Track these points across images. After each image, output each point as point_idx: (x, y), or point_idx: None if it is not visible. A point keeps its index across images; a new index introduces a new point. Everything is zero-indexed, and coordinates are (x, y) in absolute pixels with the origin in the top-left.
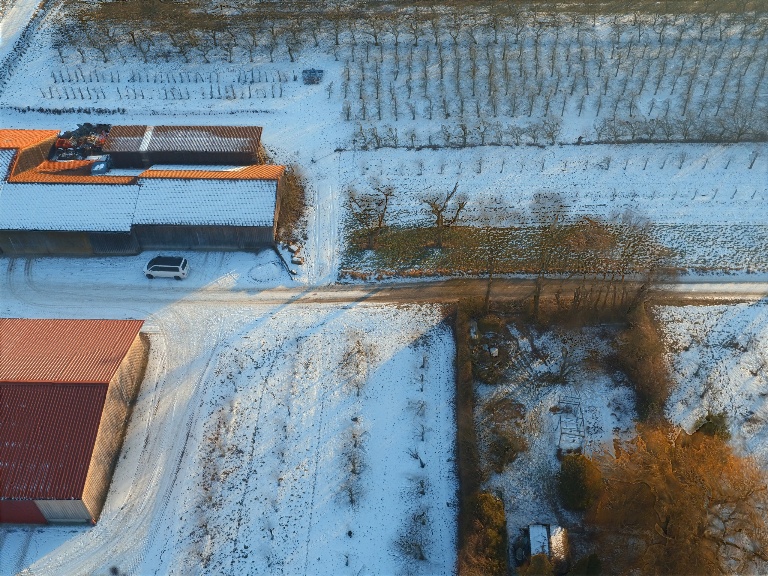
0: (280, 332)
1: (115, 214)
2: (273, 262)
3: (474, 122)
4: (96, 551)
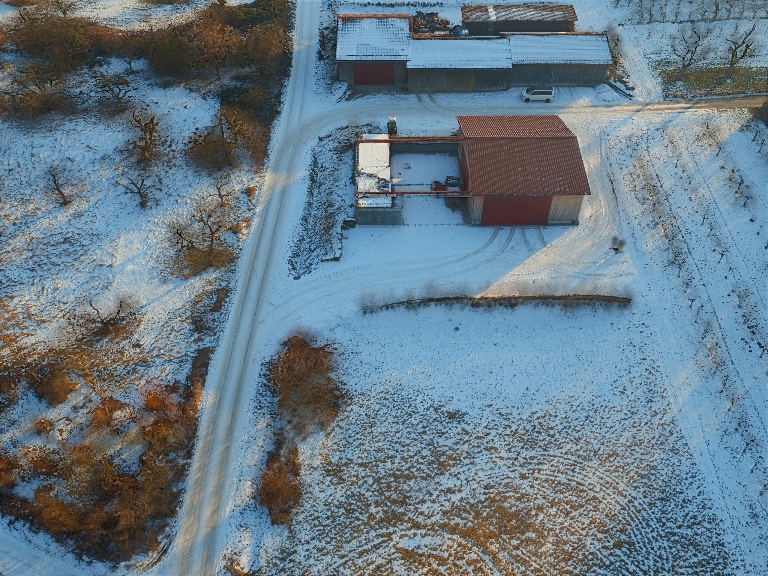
0: (642, 126)
1: (498, 58)
2: (612, 90)
3: (713, 6)
4: (588, 236)
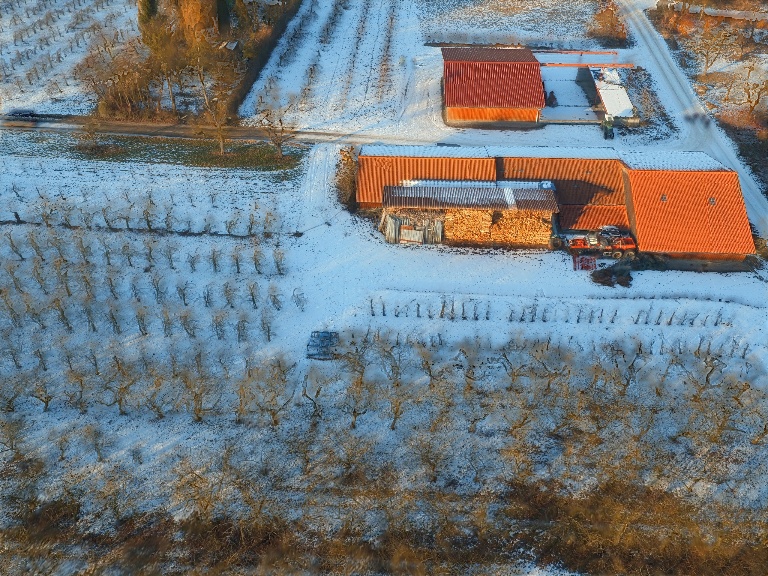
0: None
1: None
2: None
3: None
4: (437, 72)
